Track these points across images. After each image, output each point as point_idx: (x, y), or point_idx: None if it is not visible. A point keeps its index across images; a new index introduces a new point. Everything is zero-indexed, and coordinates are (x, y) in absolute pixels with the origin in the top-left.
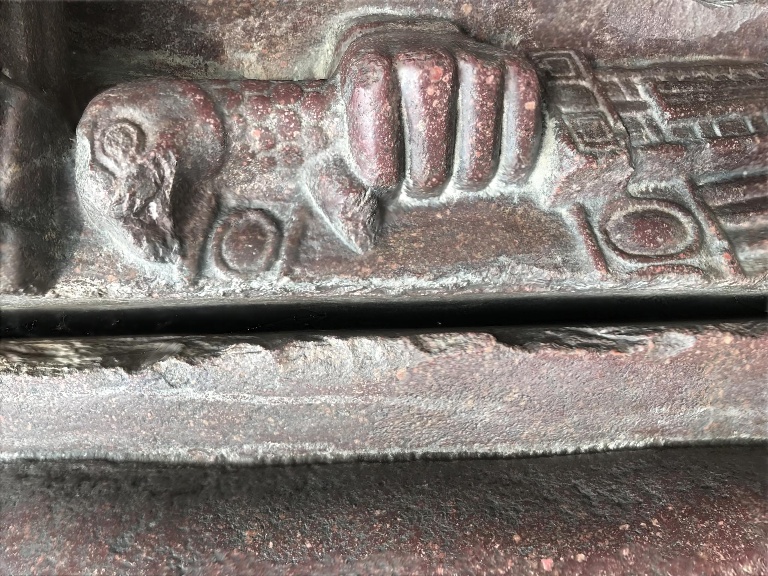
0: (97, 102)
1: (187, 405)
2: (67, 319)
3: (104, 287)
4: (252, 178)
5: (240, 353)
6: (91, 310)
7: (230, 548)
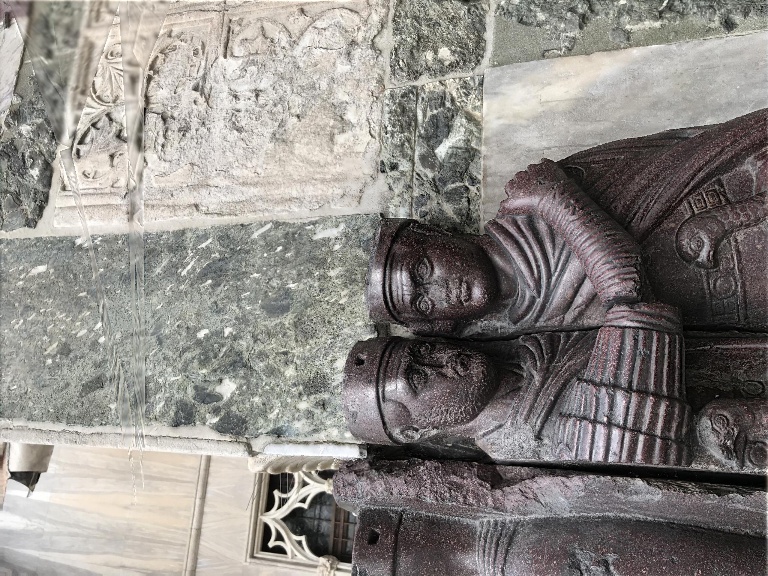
0: (711, 408)
1: (737, 511)
2: (677, 473)
3: (708, 466)
4: (759, 431)
5: (761, 495)
6: (684, 470)
7: (764, 562)
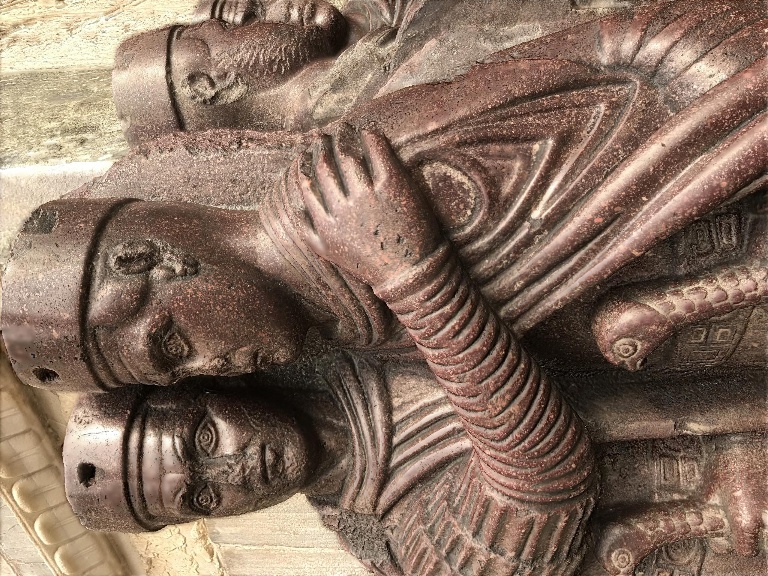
0: None
1: None
2: None
3: (595, 11)
4: None
5: None
6: None
7: None
